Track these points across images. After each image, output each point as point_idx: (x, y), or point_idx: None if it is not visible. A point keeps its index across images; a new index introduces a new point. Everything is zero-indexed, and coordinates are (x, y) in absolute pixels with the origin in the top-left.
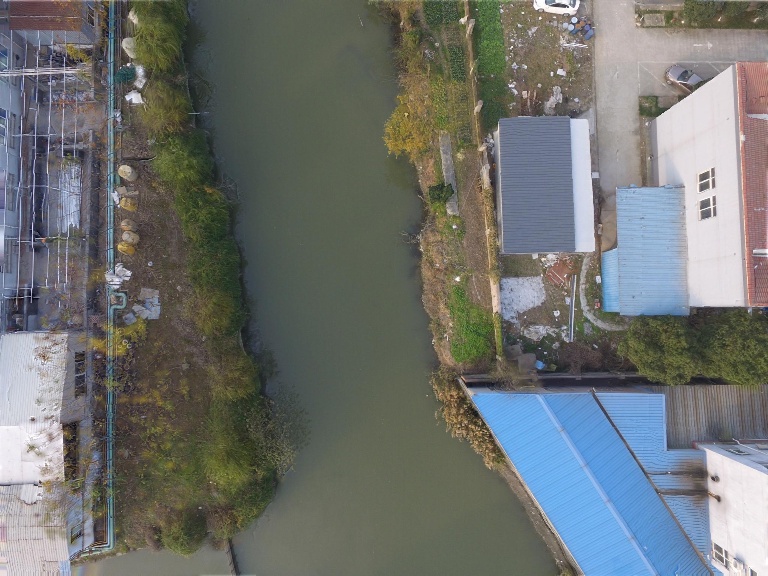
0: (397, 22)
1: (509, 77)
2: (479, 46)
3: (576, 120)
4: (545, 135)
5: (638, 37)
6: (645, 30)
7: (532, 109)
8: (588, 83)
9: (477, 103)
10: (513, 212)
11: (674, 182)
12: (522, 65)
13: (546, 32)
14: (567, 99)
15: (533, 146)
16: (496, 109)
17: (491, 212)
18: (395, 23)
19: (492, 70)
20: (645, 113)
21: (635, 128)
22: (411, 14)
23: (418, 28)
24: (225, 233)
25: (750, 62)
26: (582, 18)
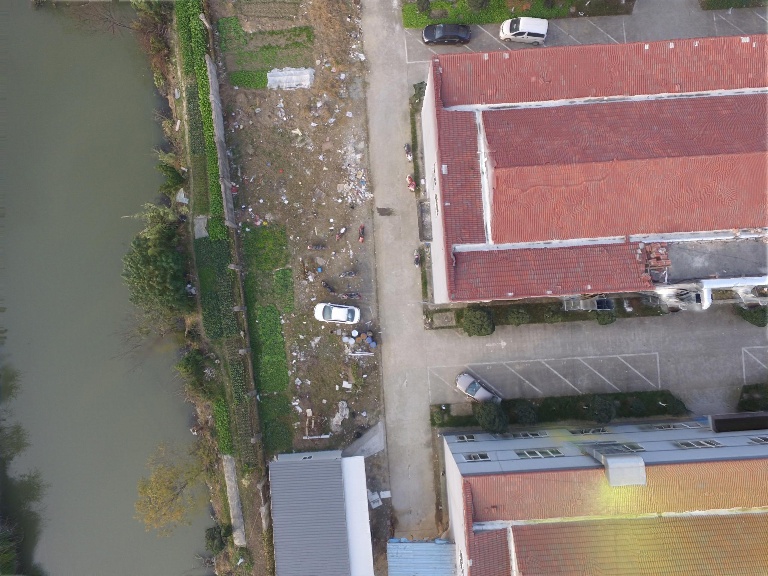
0: (181, 330)
1: (292, 395)
2: (261, 361)
3: (350, 459)
4: (316, 480)
5: (427, 340)
6: (434, 332)
7: (318, 427)
8: (376, 394)
9: (258, 427)
10: (286, 565)
11: (452, 526)
12: (306, 380)
13: (330, 342)
14: (354, 414)
15: (304, 492)
16: (280, 430)
17: (268, 558)
18: (179, 332)
19: (274, 387)
20: (437, 423)
21: (427, 440)
22: (192, 326)
23: (199, 343)
24: (11, 575)
25: (475, 477)
26: (367, 323)
